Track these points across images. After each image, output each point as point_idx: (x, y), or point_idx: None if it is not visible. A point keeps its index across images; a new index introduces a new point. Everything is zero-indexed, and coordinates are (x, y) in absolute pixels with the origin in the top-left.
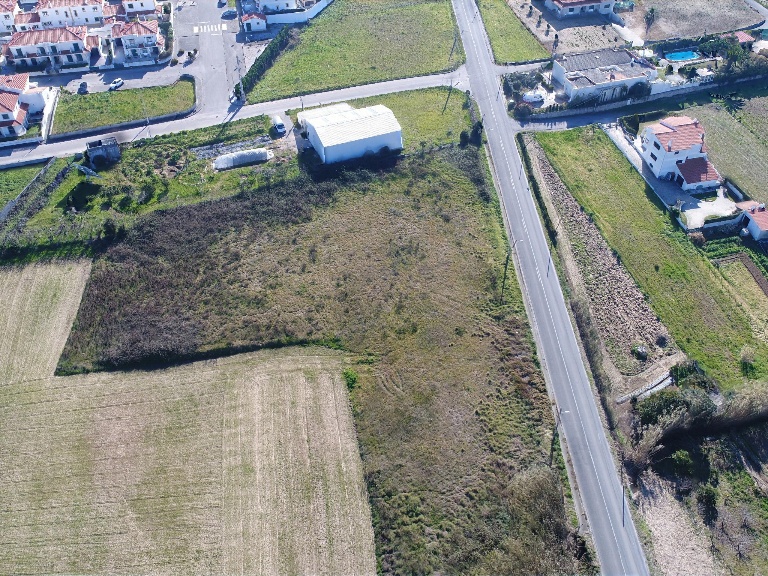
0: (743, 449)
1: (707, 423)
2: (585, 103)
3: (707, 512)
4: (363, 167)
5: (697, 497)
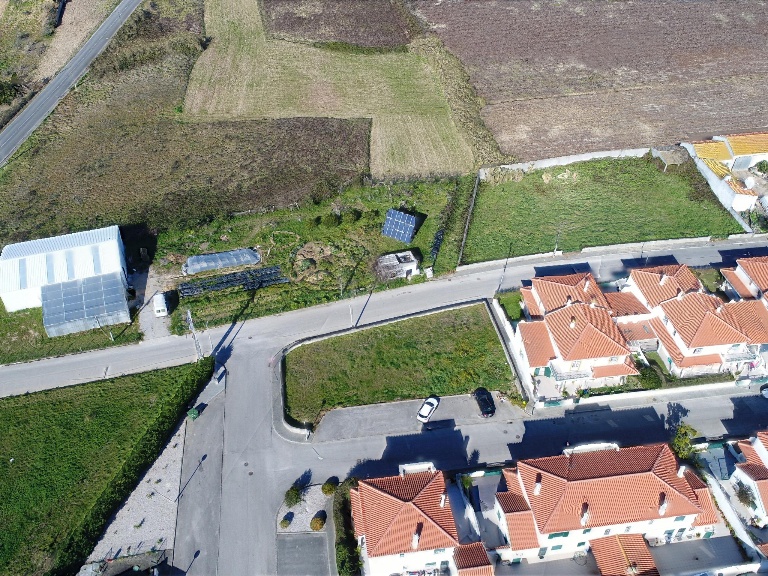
0: None
1: None
2: None
3: None
4: None
5: None
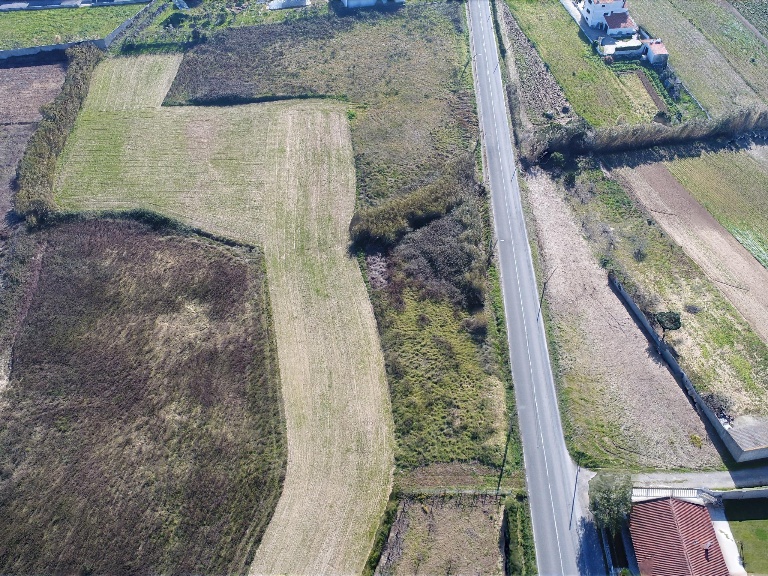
0: (603, 161)
1: (582, 147)
2: None
3: (568, 185)
4: (374, 10)
5: (564, 179)
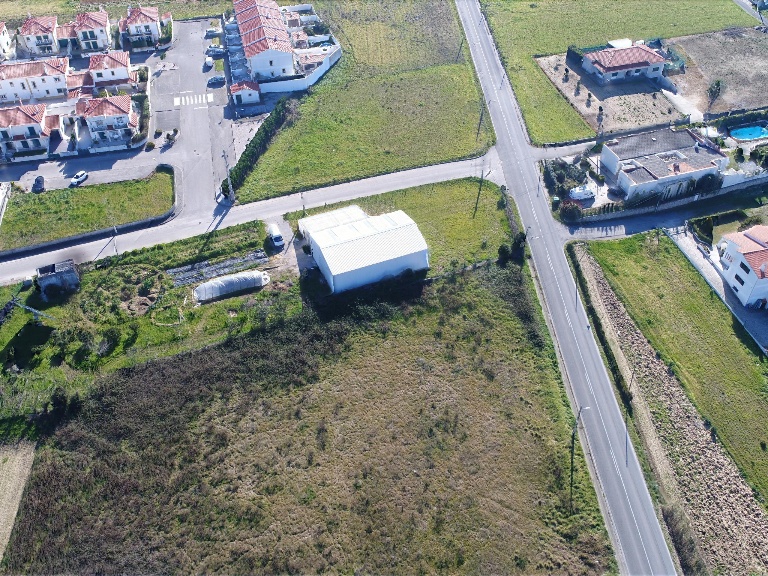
0: None
1: None
2: (645, 201)
3: None
4: (381, 299)
5: None
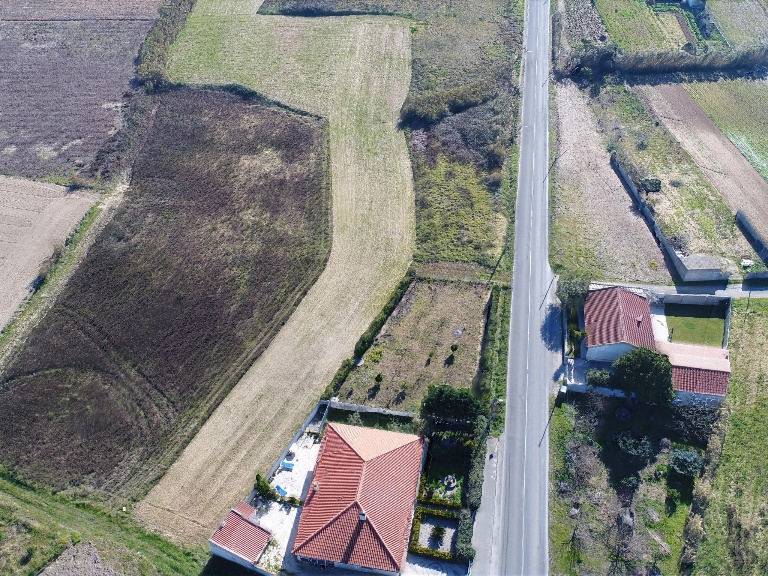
0: (628, 79)
1: (611, 67)
2: None
3: (593, 94)
4: None
5: (590, 89)
